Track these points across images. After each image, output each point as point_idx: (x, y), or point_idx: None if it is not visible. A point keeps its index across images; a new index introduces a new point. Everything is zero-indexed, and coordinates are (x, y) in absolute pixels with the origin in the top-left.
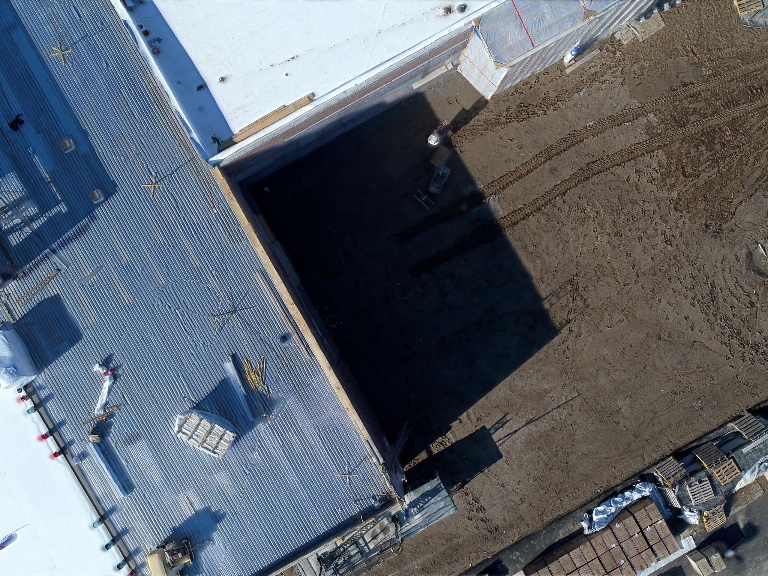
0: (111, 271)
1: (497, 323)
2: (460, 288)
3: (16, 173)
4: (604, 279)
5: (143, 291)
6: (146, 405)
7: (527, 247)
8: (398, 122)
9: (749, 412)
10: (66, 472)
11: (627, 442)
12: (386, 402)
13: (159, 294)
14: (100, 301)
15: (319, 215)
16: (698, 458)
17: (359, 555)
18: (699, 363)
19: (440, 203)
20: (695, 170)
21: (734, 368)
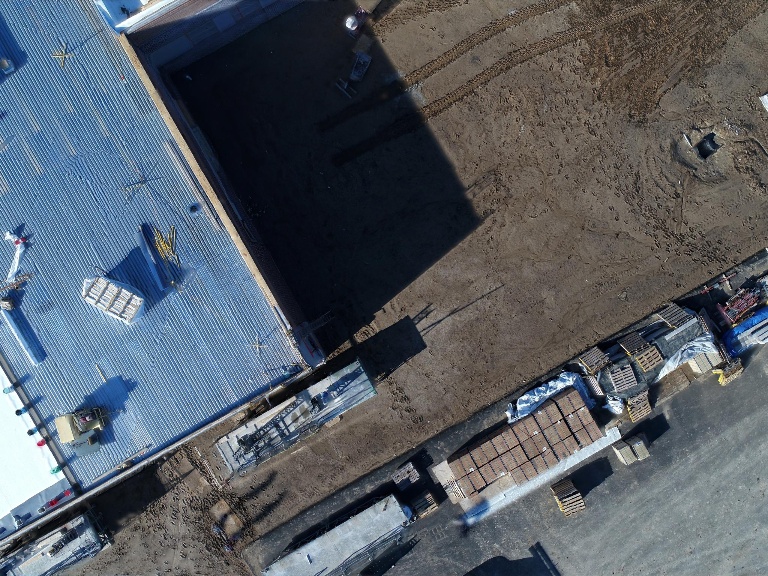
0: (22, 141)
1: (420, 213)
2: (383, 178)
3: None
4: (528, 169)
5: (54, 161)
6: (57, 274)
7: (450, 137)
8: (320, 12)
9: (674, 302)
10: None
11: (552, 333)
12: (309, 291)
13: (70, 165)
14: (11, 171)
15: (242, 104)
16: (622, 347)
17: (279, 438)
18: (624, 254)
19: (362, 92)
20: (618, 60)
21: (659, 259)
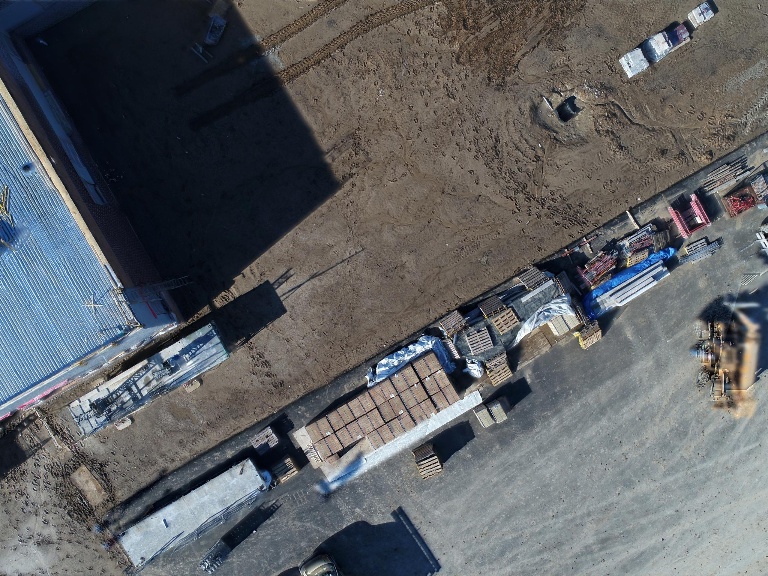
0: None
1: (279, 177)
2: (241, 142)
3: None
4: (386, 133)
5: None
6: None
7: (308, 101)
8: None
9: (535, 266)
10: None
11: (413, 297)
12: (168, 256)
13: None
14: None
15: (98, 70)
16: (481, 310)
17: (131, 402)
18: (485, 217)
19: (219, 57)
20: (477, 23)
21: (520, 222)
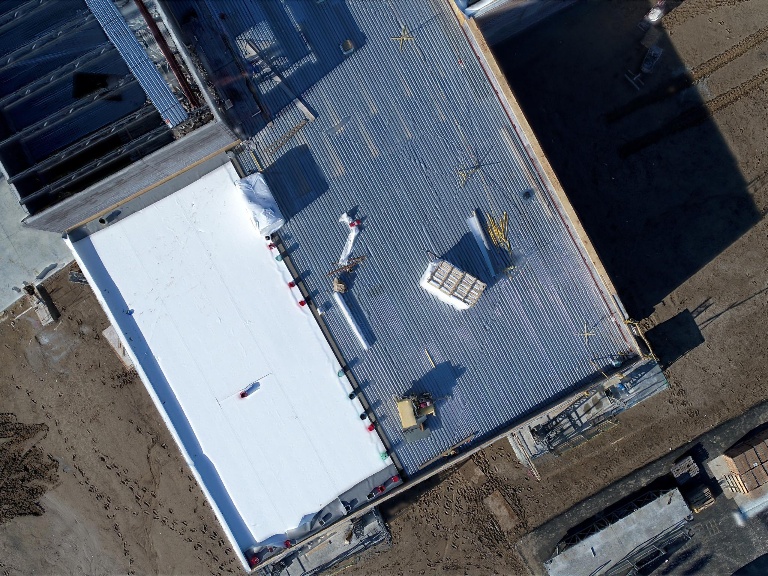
0: (358, 122)
1: (702, 206)
2: (666, 170)
3: (267, 22)
4: None
5: (389, 143)
6: (389, 258)
7: (734, 131)
8: (610, 2)
9: None
10: (310, 322)
11: None
12: None
13: None
14: (346, 152)
15: (529, 93)
16: None
17: (572, 429)
18: None
19: (649, 84)
20: None
21: None
